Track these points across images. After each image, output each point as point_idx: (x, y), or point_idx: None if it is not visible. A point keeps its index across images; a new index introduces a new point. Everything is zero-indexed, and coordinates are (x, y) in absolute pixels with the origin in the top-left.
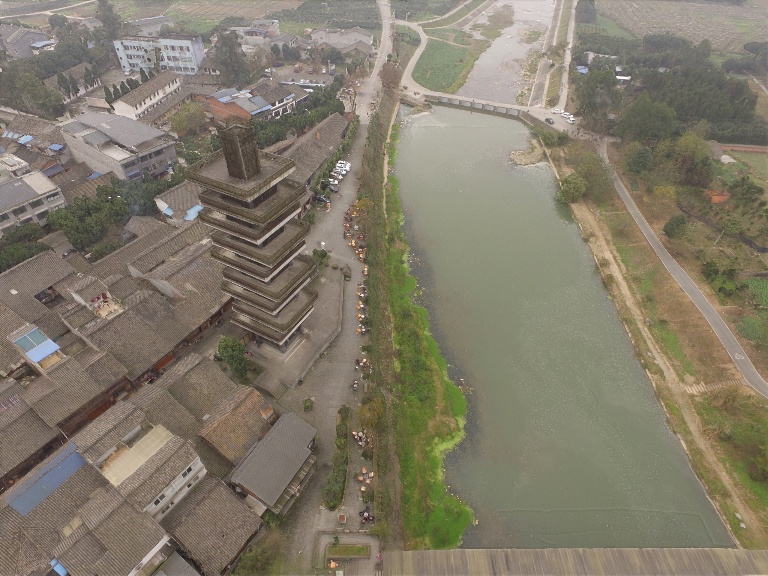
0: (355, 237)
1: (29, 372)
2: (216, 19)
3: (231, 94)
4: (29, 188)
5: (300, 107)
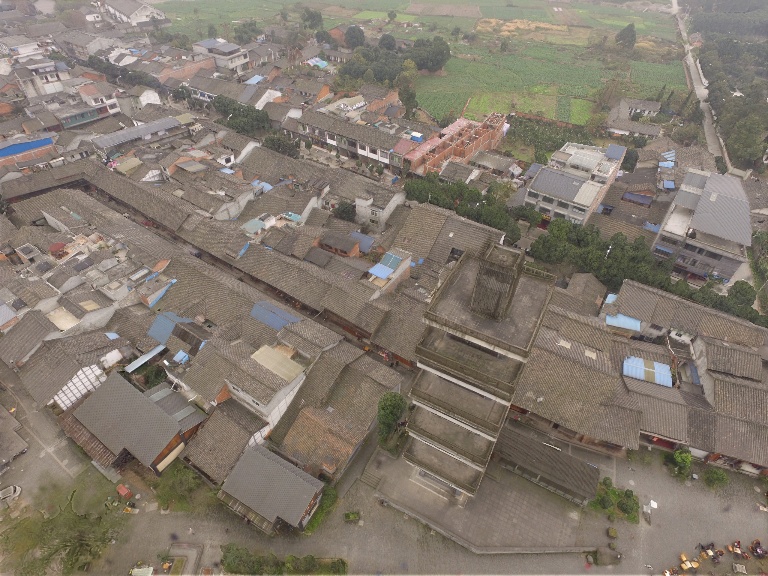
0: (712, 568)
1: None
2: None
3: None
4: (576, 192)
5: None
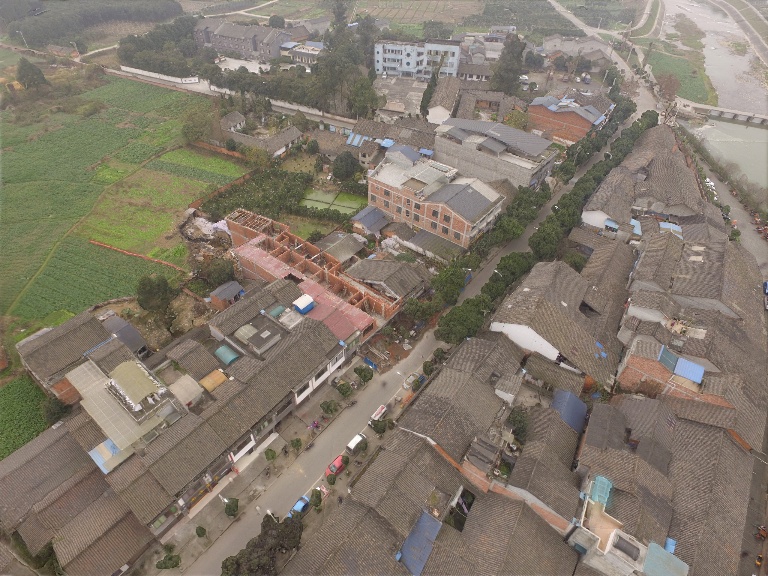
0: None
1: (618, 388)
2: (412, 23)
3: (555, 103)
4: (481, 195)
5: (617, 118)
